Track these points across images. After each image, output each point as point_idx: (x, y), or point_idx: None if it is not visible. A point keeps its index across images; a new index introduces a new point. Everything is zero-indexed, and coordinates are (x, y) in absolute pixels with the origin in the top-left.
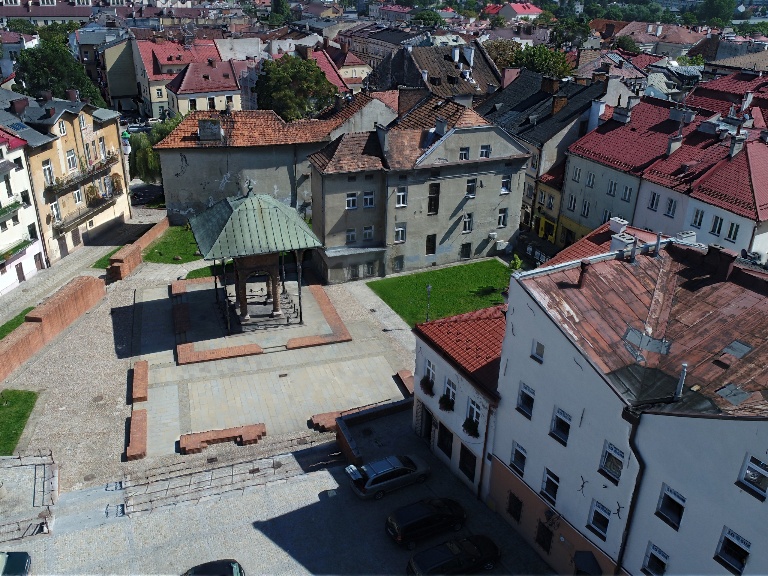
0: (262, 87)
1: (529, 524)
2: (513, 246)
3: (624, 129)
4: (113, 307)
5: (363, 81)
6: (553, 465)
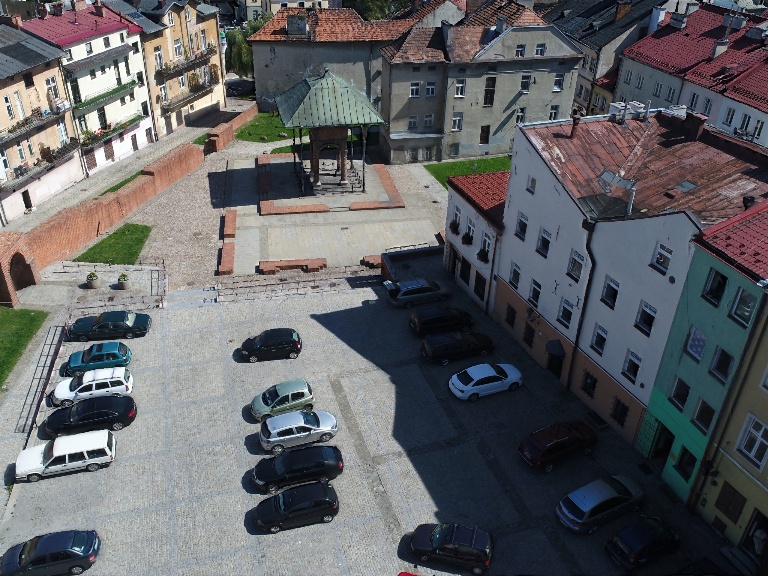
0: None
1: (520, 327)
2: None
3: (678, 34)
4: (210, 172)
5: None
6: (537, 275)
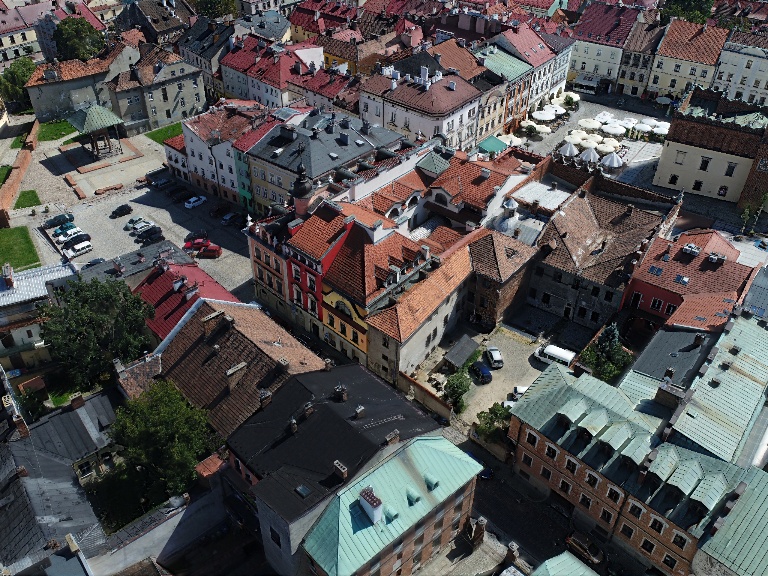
0: (59, 38)
1: (203, 185)
2: (206, 109)
3: (242, 51)
4: (39, 161)
5: (113, 21)
6: (202, 167)
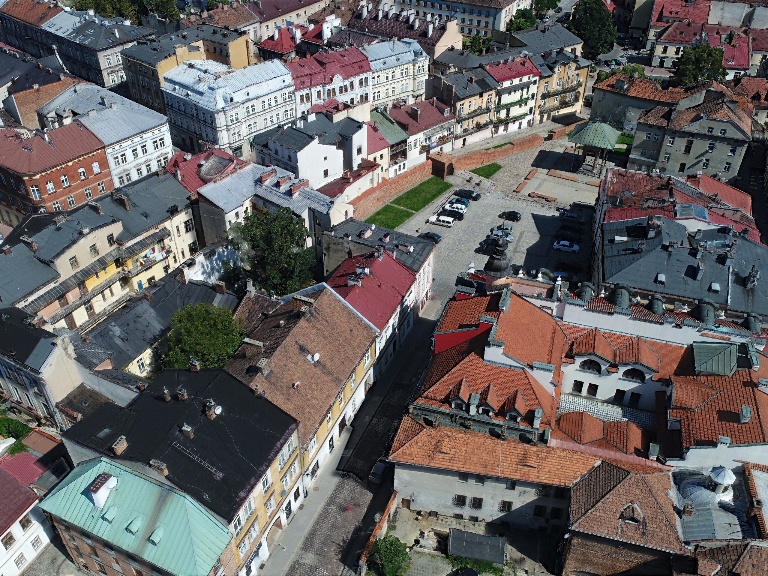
0: None
1: None
2: (730, 183)
3: None
4: (542, 149)
5: (760, 64)
6: None
